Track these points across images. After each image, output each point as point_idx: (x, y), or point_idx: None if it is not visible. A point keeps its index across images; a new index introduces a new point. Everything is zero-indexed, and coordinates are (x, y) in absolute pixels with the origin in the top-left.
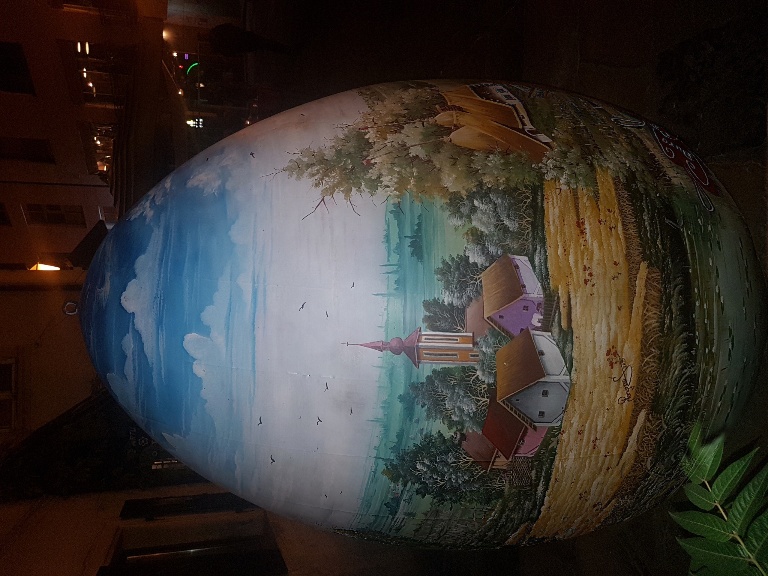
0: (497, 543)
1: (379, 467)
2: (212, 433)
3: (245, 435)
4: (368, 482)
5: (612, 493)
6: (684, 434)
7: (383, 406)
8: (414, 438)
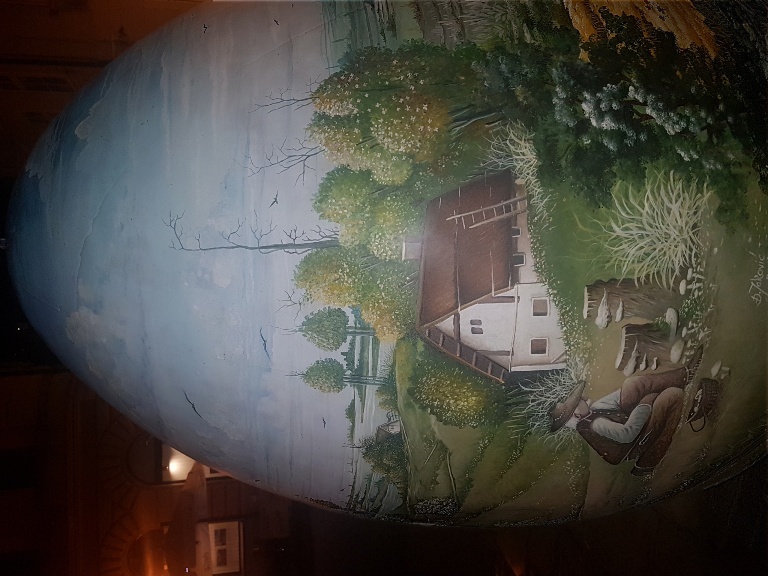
0: (565, 33)
1: None
2: (137, 60)
3: (175, 33)
4: None
5: None
6: None
7: None
8: None
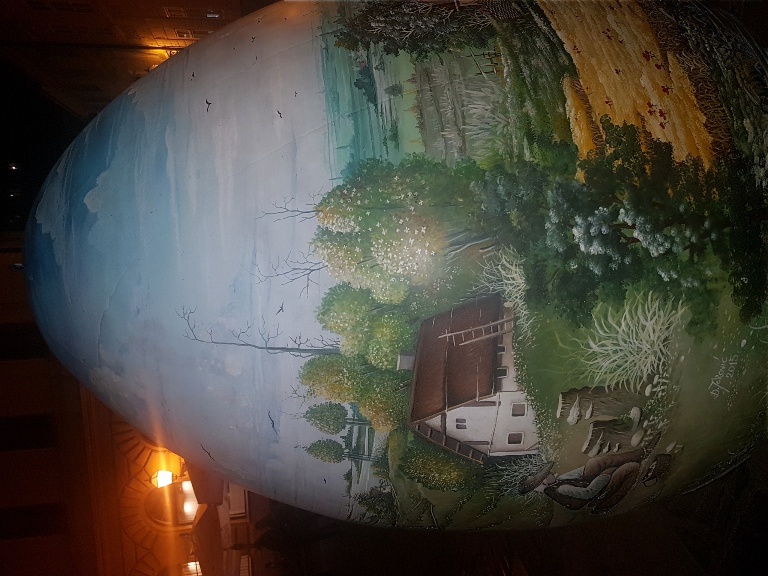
0: (564, 148)
1: (329, 42)
2: (141, 127)
3: (177, 99)
4: (323, 63)
5: (653, 41)
6: (683, 2)
7: (316, 4)
8: (357, 7)
